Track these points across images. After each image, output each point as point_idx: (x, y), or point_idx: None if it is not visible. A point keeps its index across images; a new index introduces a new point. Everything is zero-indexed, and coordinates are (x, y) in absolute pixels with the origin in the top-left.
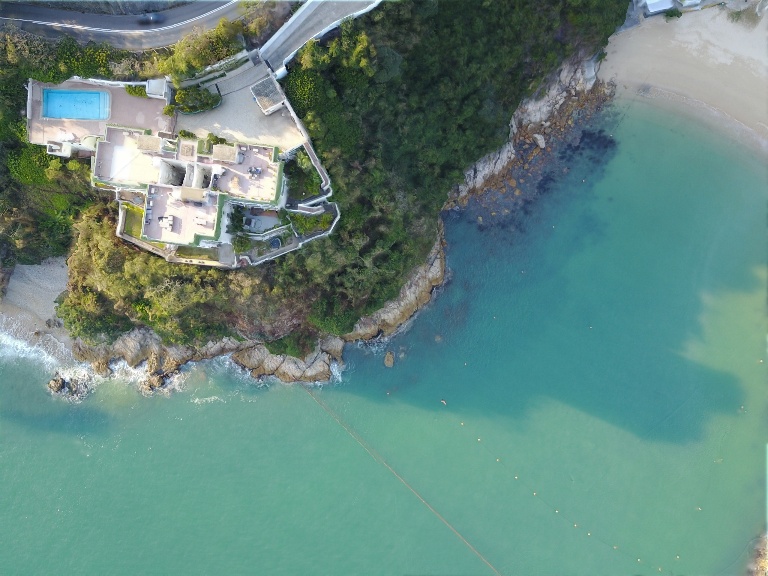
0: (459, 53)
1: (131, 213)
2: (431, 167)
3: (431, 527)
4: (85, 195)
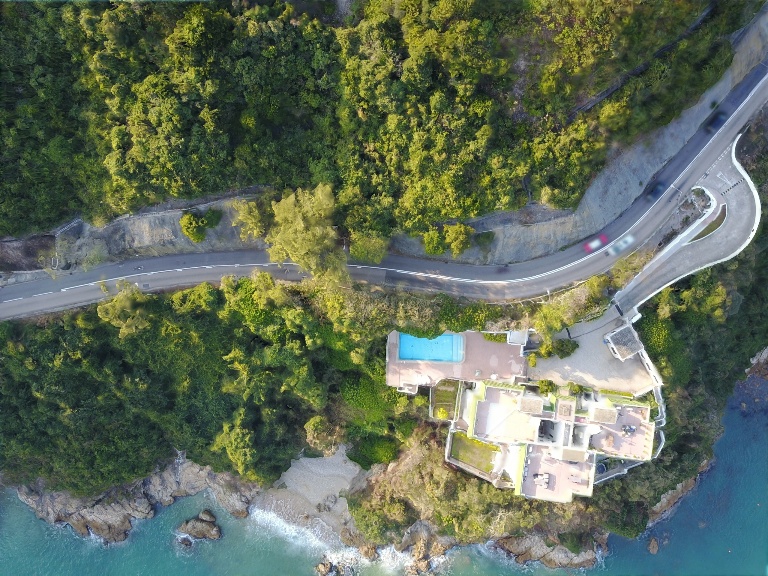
0: None
1: (457, 437)
2: None
3: None
4: (402, 412)
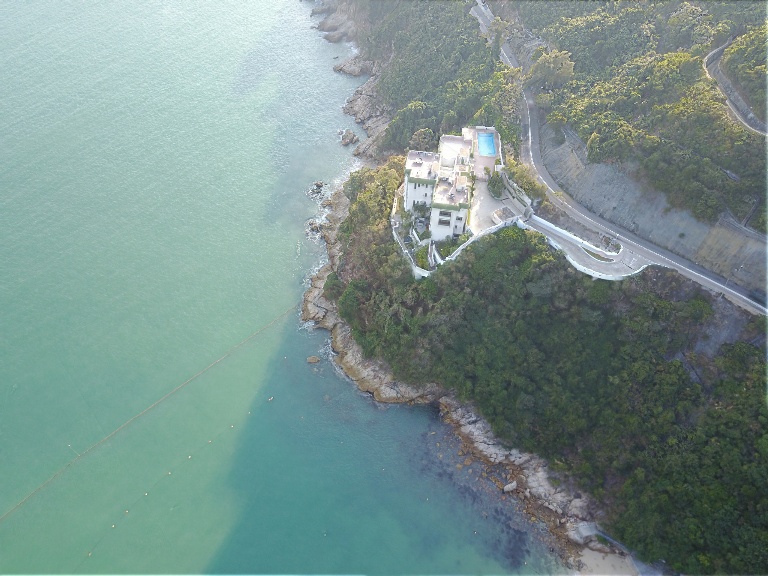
0: (566, 363)
1: None
2: (472, 362)
3: (165, 388)
4: None
